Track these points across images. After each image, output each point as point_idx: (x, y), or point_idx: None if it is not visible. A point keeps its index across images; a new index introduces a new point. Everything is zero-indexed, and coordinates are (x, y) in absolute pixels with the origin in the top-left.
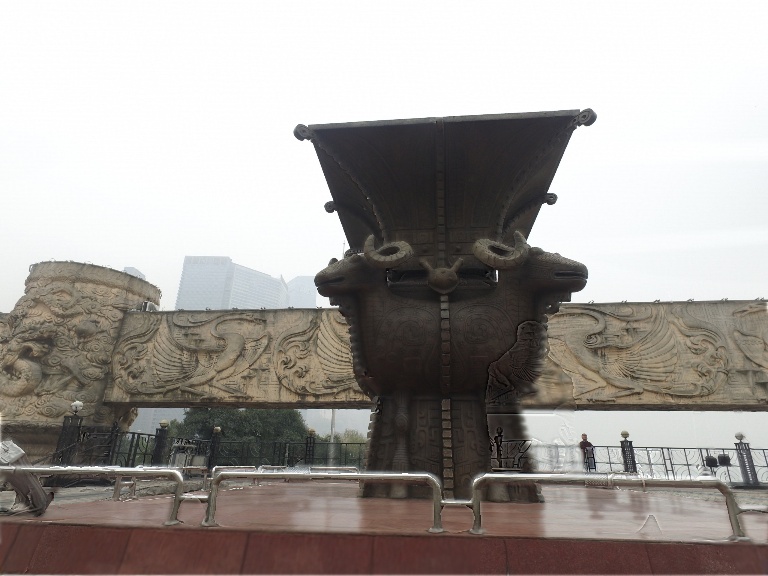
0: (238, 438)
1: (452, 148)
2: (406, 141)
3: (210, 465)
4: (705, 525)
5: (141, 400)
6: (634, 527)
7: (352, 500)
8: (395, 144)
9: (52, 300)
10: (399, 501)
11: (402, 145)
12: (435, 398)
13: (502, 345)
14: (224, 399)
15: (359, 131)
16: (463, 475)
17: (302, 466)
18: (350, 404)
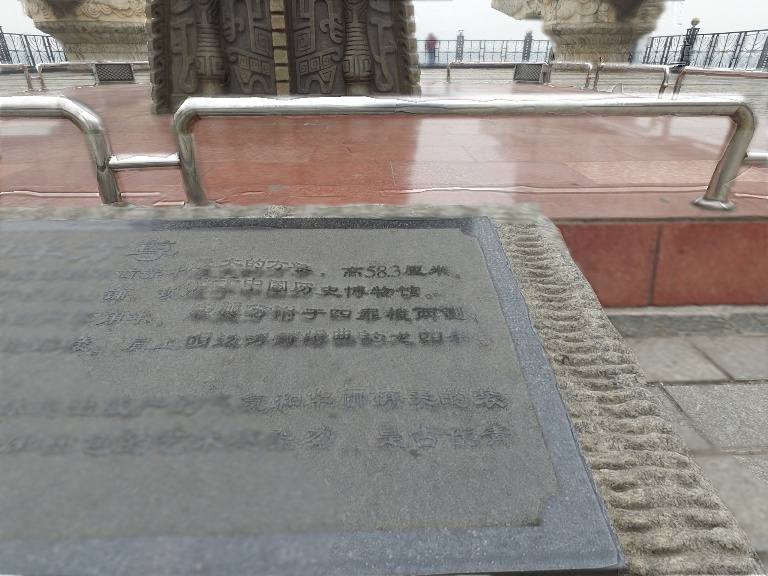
0: None
1: None
2: None
3: None
4: None
5: None
6: None
7: None
8: None
9: None
10: None
11: None
12: None
13: None
14: None
15: None
16: None
17: None
18: None
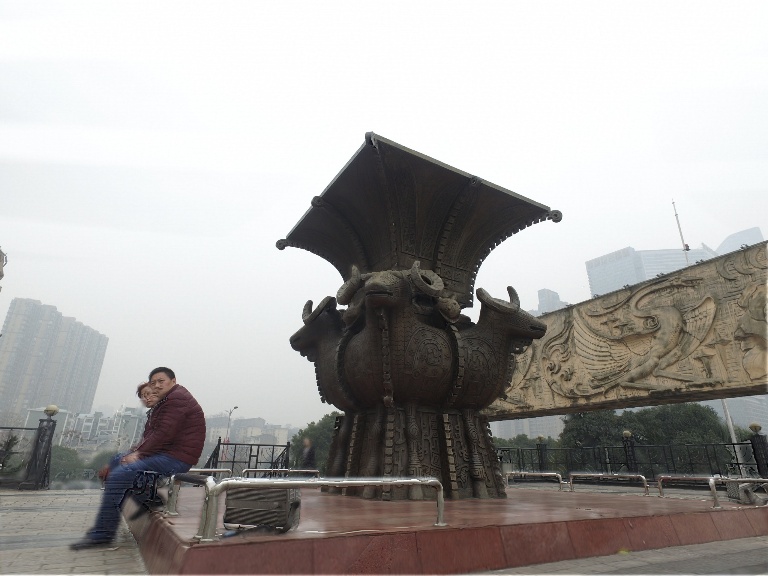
0: (616, 443)
1: (343, 207)
2: (322, 218)
3: (542, 471)
4: None
5: None
6: None
7: None
8: (320, 223)
9: None
10: (315, 494)
11: (323, 222)
12: (360, 414)
13: (364, 365)
14: (512, 410)
15: (301, 227)
16: (361, 476)
17: (626, 472)
18: (627, 402)
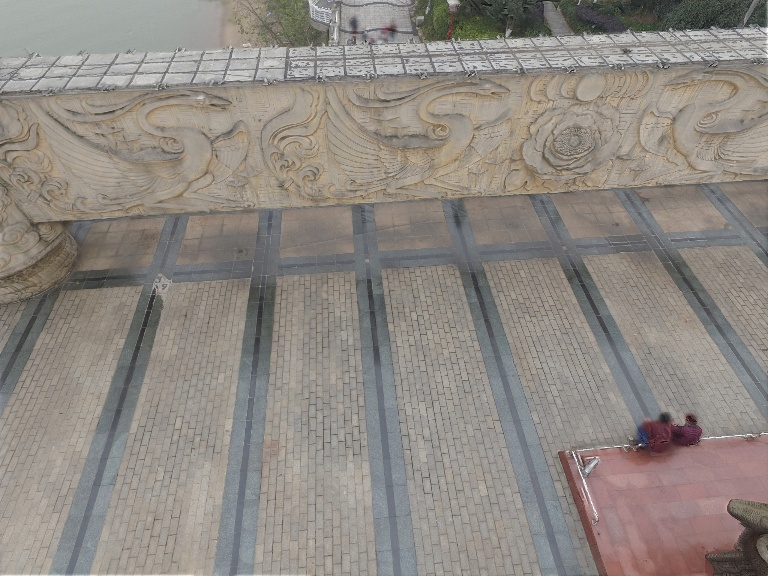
0: None
1: None
2: None
3: None
4: (640, 479)
5: None
6: (657, 465)
7: None
8: None
9: None
10: None
11: None
12: None
13: None
14: None
15: None
16: None
17: None
18: None
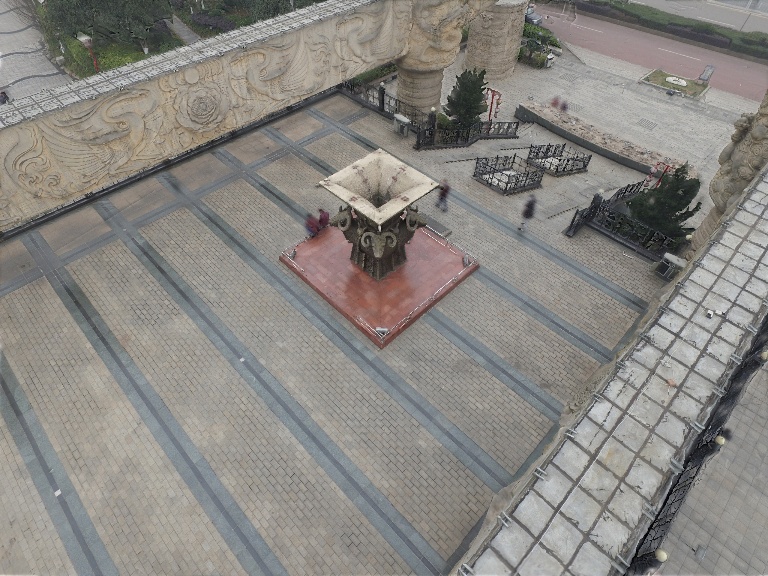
0: None
1: None
2: None
3: None
4: None
5: None
6: None
7: None
8: None
9: (767, 94)
10: None
11: None
12: None
13: None
14: None
15: None
16: None
17: None
18: None
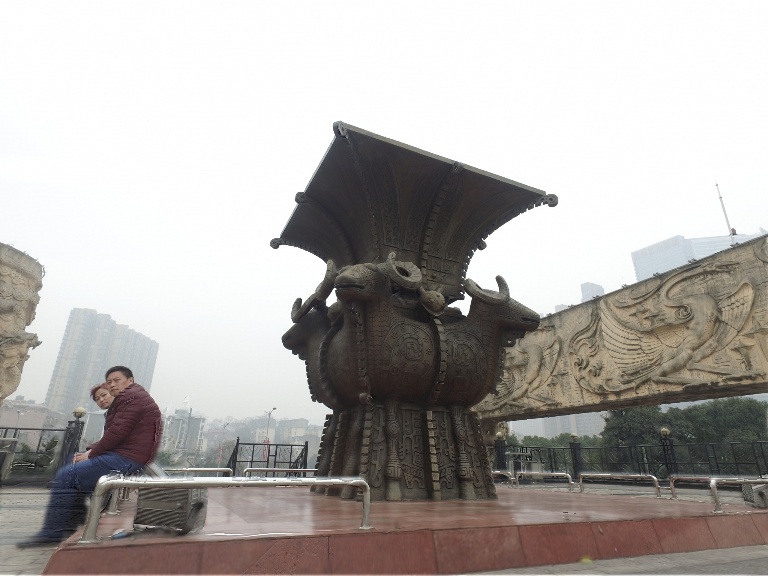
0: None
1: (326, 202)
2: (309, 214)
3: (576, 471)
4: None
5: (488, 416)
6: None
7: (292, 492)
8: (308, 220)
9: None
10: None
11: (311, 218)
12: (346, 412)
13: (342, 362)
14: (540, 408)
15: (292, 224)
16: (343, 476)
17: (665, 472)
18: (660, 397)
